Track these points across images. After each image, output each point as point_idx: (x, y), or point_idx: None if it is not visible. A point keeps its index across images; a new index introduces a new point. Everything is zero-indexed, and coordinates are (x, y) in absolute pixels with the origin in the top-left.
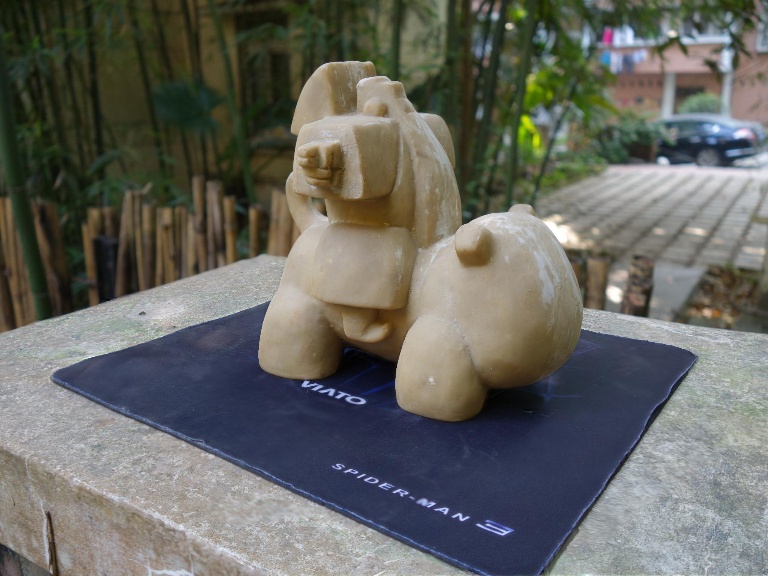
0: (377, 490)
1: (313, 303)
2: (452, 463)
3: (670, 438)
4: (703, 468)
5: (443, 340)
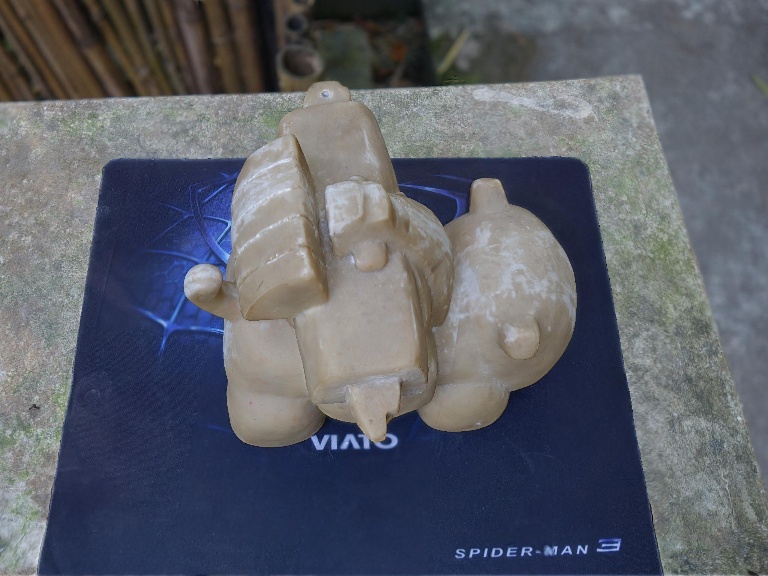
0: (510, 562)
1: (308, 400)
2: (531, 486)
3: (635, 332)
4: (673, 363)
5: (489, 401)
